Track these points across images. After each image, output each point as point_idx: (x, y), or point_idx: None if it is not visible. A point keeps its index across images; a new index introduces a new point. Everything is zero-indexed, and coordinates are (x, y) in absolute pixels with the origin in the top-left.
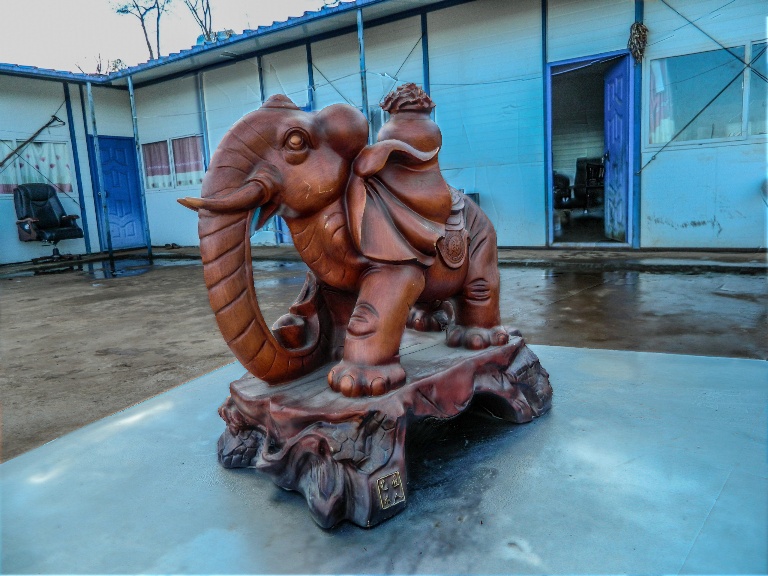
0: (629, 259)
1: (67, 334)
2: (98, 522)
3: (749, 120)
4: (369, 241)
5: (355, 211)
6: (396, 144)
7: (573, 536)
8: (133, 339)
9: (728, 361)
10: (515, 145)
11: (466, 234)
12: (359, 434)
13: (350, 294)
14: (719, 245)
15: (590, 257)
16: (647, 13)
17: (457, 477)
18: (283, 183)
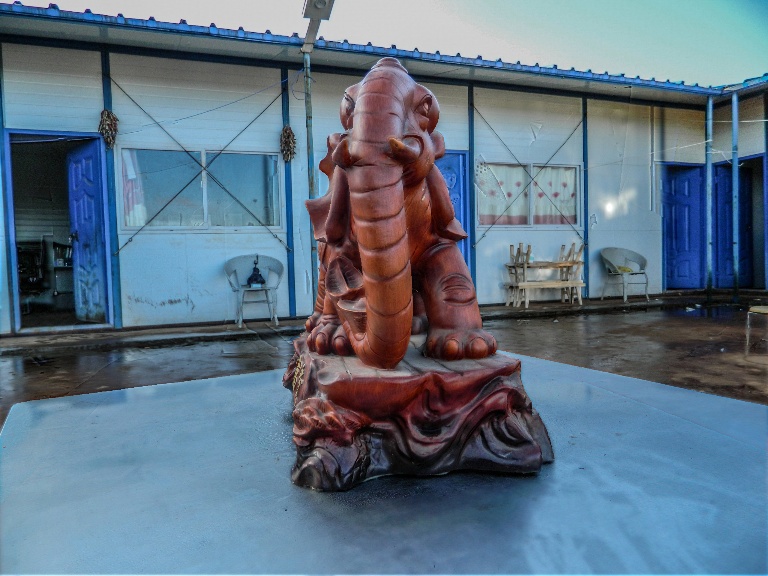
0: (120, 338)
1: None
2: None
3: (209, 213)
4: None
5: (442, 187)
6: None
7: (621, 421)
8: None
9: None
10: None
11: None
12: None
13: None
14: (193, 320)
15: (75, 340)
16: (116, 104)
17: None
18: None
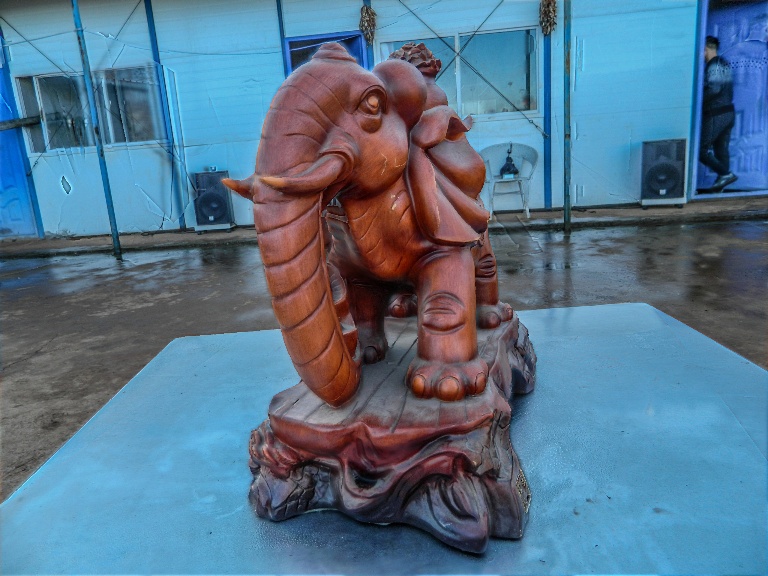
0: None
1: None
2: None
3: (462, 102)
4: None
5: (426, 188)
6: (452, 110)
7: (689, 485)
8: None
9: (612, 307)
10: (261, 120)
11: None
12: (490, 439)
13: (391, 285)
14: None
15: None
16: None
17: (536, 459)
18: (360, 156)
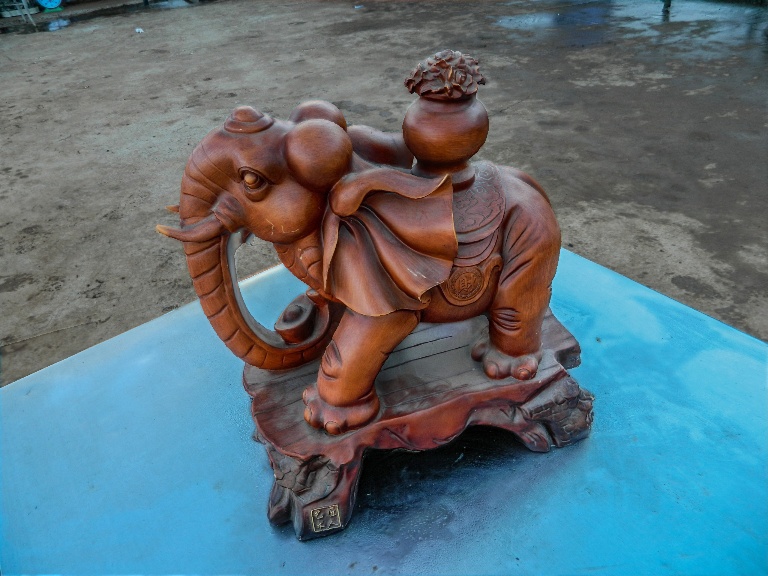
0: None
1: (315, 76)
2: (147, 434)
3: None
4: (341, 285)
5: (324, 254)
6: (375, 182)
7: None
8: (366, 92)
9: None
10: None
11: (492, 263)
12: (301, 470)
13: None
14: None
15: None
16: None
17: (413, 508)
18: (246, 218)
